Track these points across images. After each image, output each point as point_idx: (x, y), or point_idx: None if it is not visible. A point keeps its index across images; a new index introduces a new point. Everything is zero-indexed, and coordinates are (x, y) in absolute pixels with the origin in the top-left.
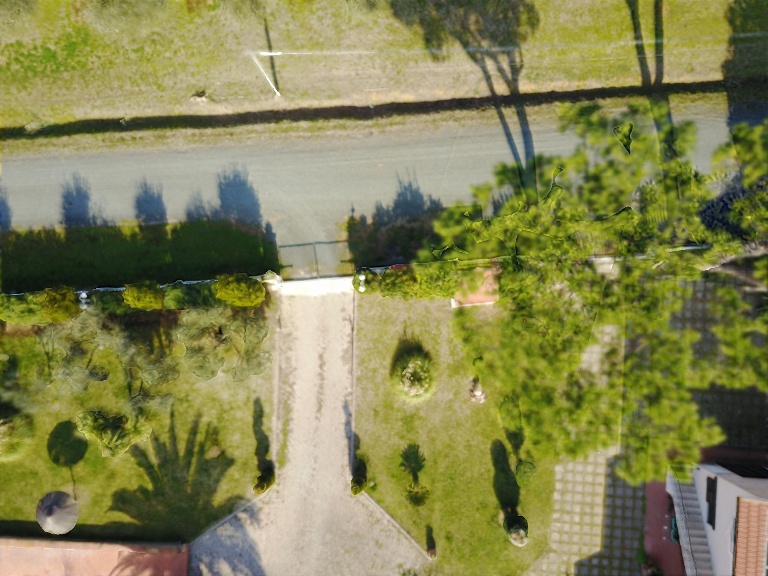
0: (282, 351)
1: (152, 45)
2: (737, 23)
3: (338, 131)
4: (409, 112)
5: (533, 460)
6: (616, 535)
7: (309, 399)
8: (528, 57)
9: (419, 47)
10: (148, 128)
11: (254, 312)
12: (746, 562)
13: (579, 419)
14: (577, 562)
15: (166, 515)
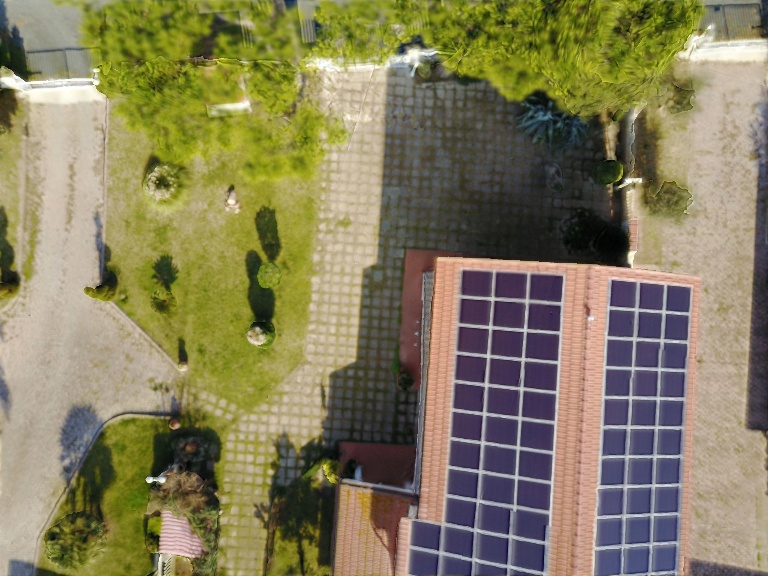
0: (30, 160)
1: None
2: None
3: None
4: None
5: (289, 271)
6: (372, 346)
7: (59, 211)
8: None
9: None
10: None
11: None
12: (441, 322)
13: (336, 230)
14: (332, 374)
15: None
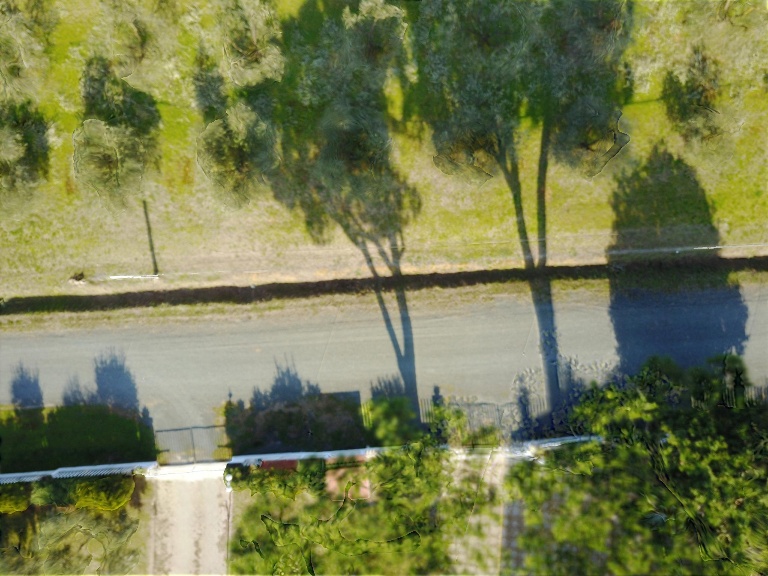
0: (157, 537)
1: (31, 227)
2: (620, 209)
3: (216, 315)
4: (288, 295)
5: None
6: None
7: None
8: (409, 240)
9: (299, 230)
10: (25, 311)
11: None
12: None
13: None
14: None
15: None
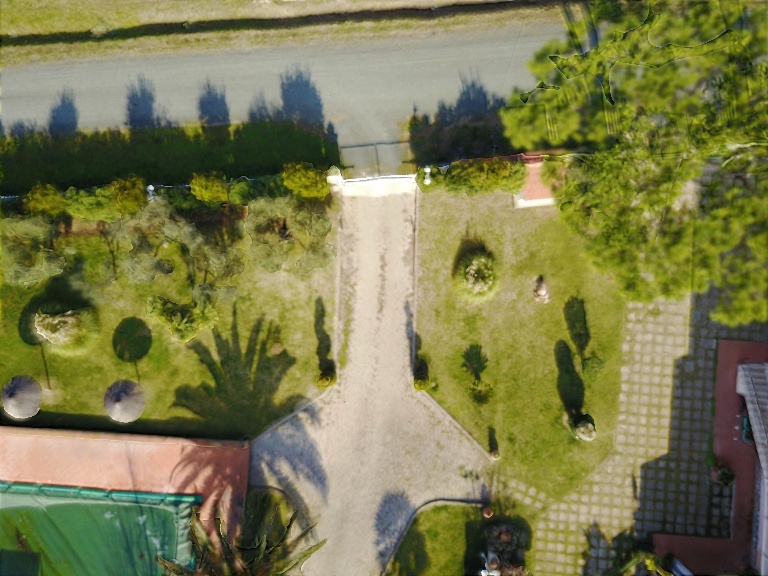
0: (343, 252)
1: None
2: None
3: (400, 31)
4: (471, 12)
5: None
6: (684, 438)
7: (370, 300)
8: None
9: None
10: (211, 30)
11: None
12: None
13: (645, 320)
14: (644, 465)
15: (229, 411)
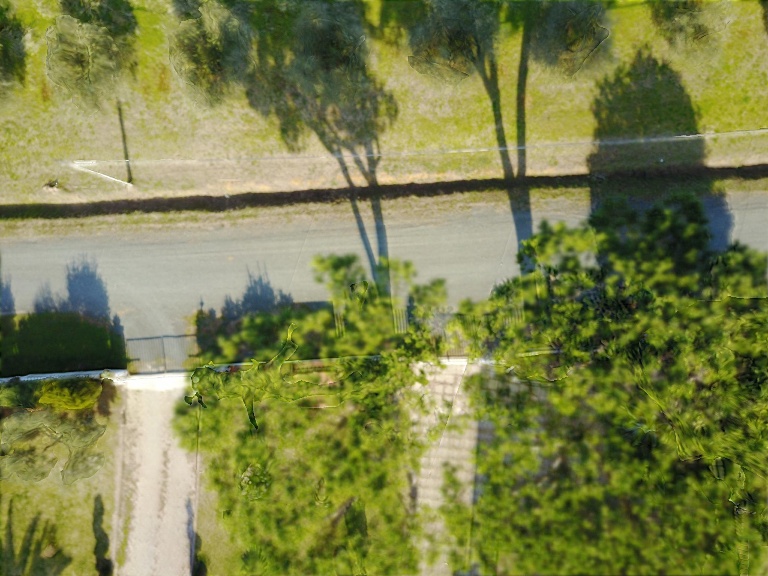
0: (126, 447)
1: (7, 134)
2: (602, 116)
3: (189, 223)
4: (262, 204)
5: (378, 569)
6: None
7: (152, 497)
8: (386, 149)
9: (274, 137)
10: None
11: (98, 407)
12: None
13: (427, 528)
14: None
15: None
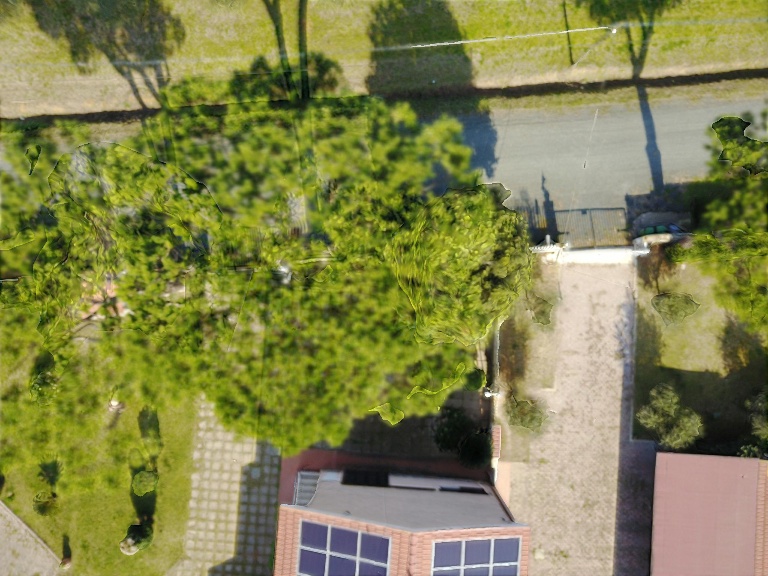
0: None
1: None
2: (378, 40)
3: None
4: (55, 124)
5: (170, 469)
6: (249, 542)
7: None
8: (175, 71)
9: (65, 60)
10: None
11: None
12: (282, 569)
13: (216, 428)
14: (211, 569)
15: None
